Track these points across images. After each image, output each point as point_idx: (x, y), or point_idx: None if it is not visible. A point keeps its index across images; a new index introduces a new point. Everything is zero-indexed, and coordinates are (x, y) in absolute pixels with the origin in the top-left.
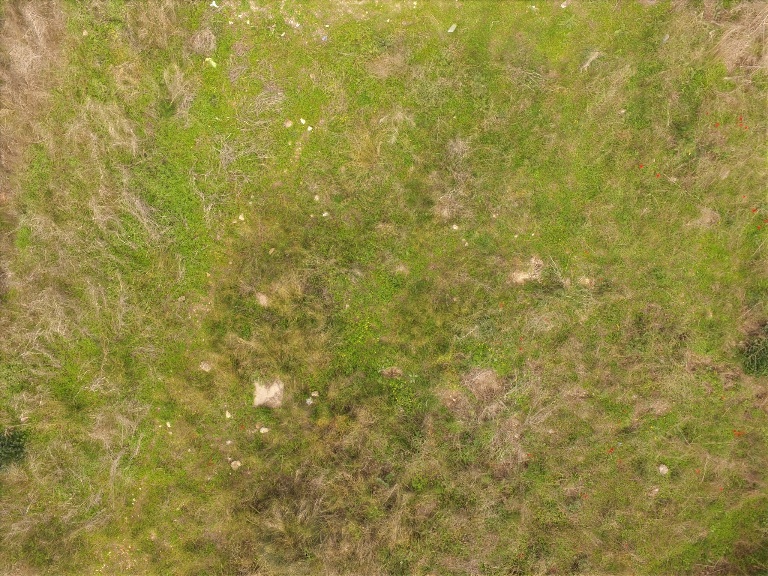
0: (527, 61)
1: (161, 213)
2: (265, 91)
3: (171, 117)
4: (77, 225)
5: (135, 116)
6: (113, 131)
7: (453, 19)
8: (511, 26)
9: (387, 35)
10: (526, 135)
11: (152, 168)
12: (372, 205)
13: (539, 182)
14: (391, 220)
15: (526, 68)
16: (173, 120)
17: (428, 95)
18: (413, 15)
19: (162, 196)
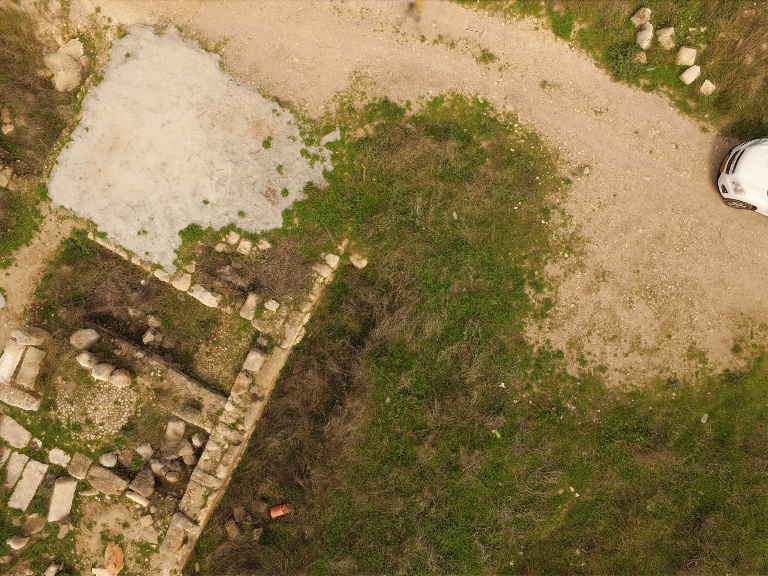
0: (766, 450)
1: (445, 559)
2: (544, 465)
3: (460, 480)
4: (371, 562)
5: (427, 474)
6: (421, 503)
7: (706, 410)
8: (753, 417)
9: (650, 423)
10: (762, 513)
11: (439, 518)
12: (625, 561)
13: (767, 550)
14: (641, 575)
15: (767, 459)
16: (461, 481)
17: (682, 476)
18: (672, 406)
19: (447, 544)
